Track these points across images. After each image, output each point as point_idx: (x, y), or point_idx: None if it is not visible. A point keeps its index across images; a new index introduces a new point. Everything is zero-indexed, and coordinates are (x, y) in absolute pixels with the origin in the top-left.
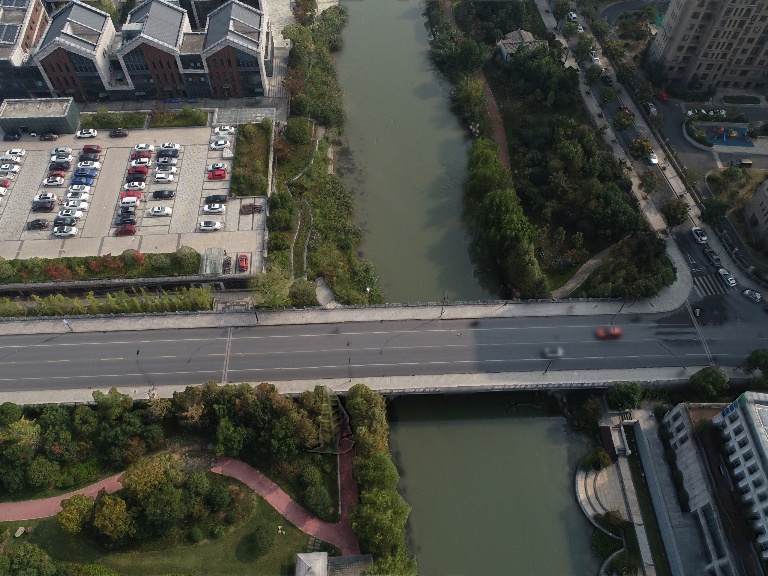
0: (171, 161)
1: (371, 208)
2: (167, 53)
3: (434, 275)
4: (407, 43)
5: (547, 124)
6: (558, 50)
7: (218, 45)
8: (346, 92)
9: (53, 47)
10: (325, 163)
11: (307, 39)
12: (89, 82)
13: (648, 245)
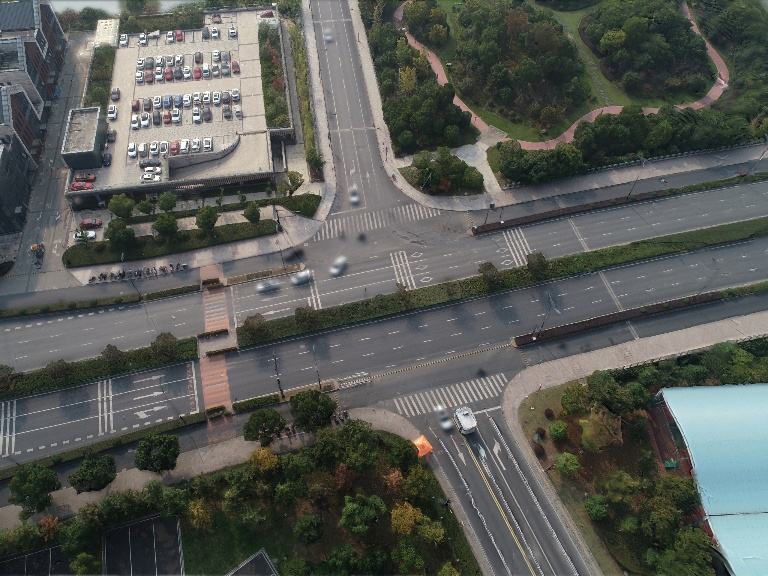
0: None
1: None
2: (33, 43)
3: None
4: None
5: None
6: None
7: (38, 9)
8: None
9: (9, 99)
10: None
11: None
12: (31, 123)
13: None
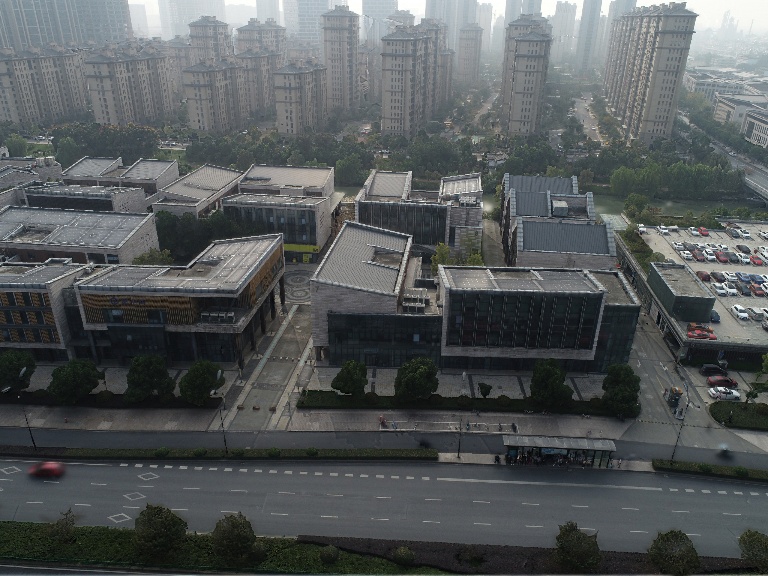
0: None
1: None
2: None
3: None
4: None
5: None
6: None
7: None
8: None
9: None
10: None
11: None
12: None
13: (703, 150)
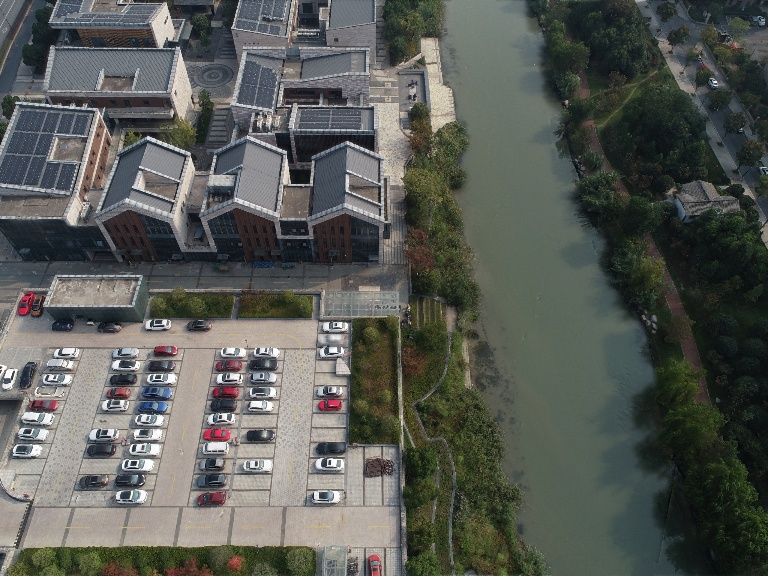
0: (269, 378)
1: (526, 446)
2: (265, 219)
3: (626, 573)
4: (545, 179)
5: (749, 324)
6: (752, 213)
7: (332, 213)
8: (474, 249)
9: (121, 209)
10: (461, 370)
11: (435, 190)
12: (161, 243)
13: None
